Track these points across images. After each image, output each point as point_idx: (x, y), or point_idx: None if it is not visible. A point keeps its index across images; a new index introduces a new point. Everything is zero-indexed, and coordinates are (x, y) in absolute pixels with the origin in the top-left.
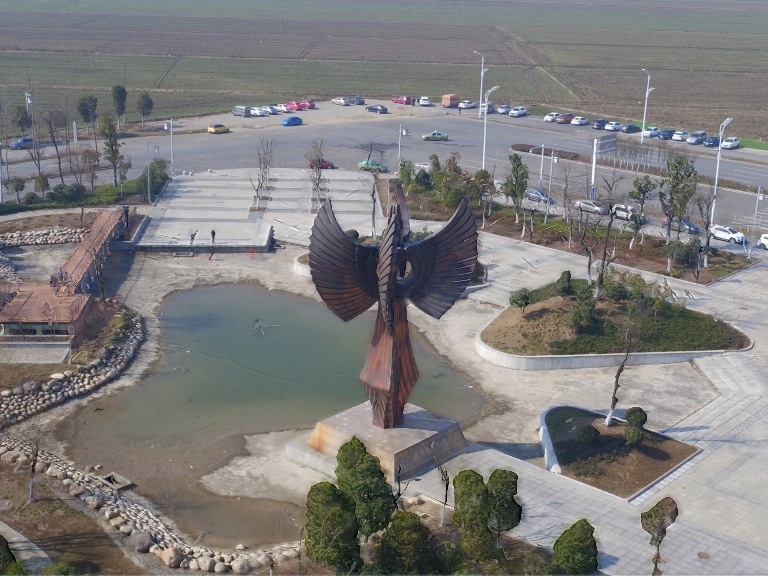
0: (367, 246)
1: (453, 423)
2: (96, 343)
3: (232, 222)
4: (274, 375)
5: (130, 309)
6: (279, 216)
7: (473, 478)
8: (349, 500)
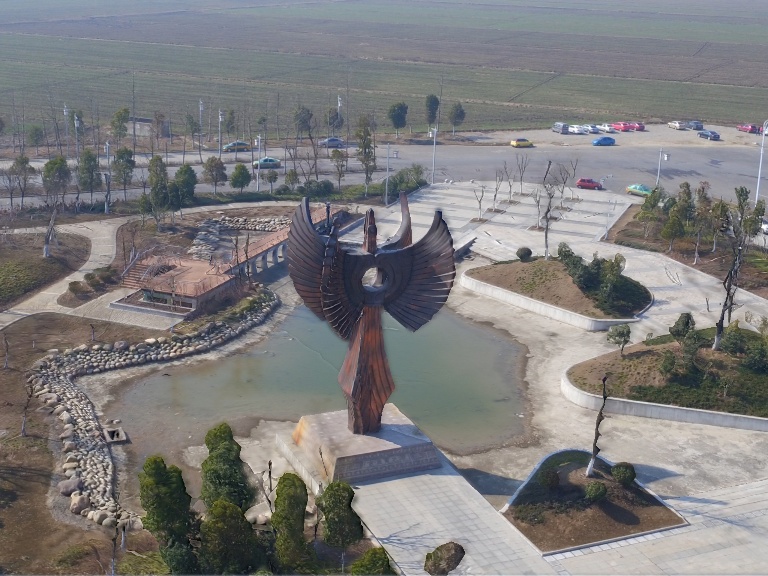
0: None
1: (426, 441)
2: (211, 319)
3: None
4: None
5: (271, 294)
6: (493, 229)
7: (289, 482)
8: (171, 478)
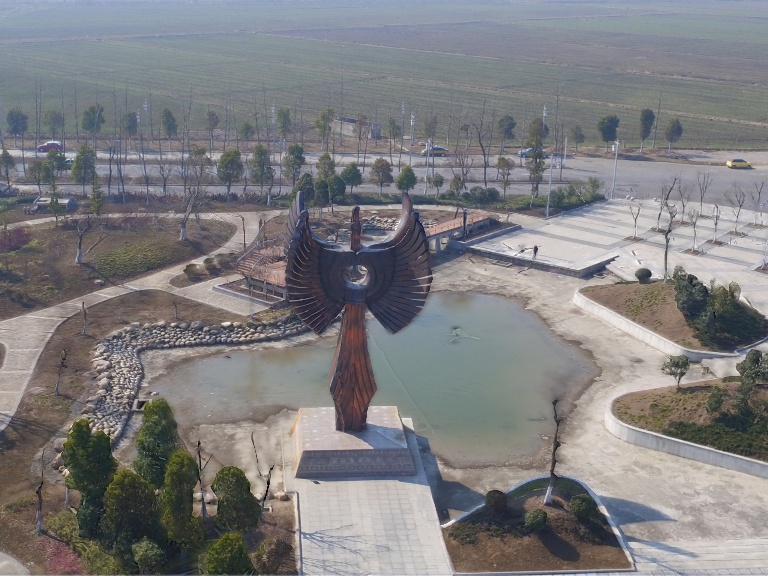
0: (324, 243)
1: (402, 447)
2: None
3: (587, 245)
4: (402, 375)
5: None
6: (643, 249)
7: (178, 459)
8: (89, 442)
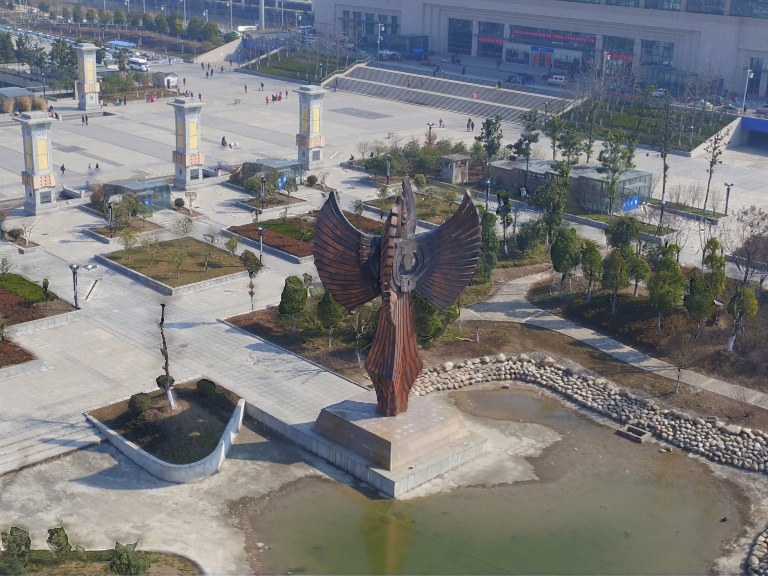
0: (427, 232)
1: (329, 408)
2: None
3: None
4: None
5: None
6: None
7: None
8: None
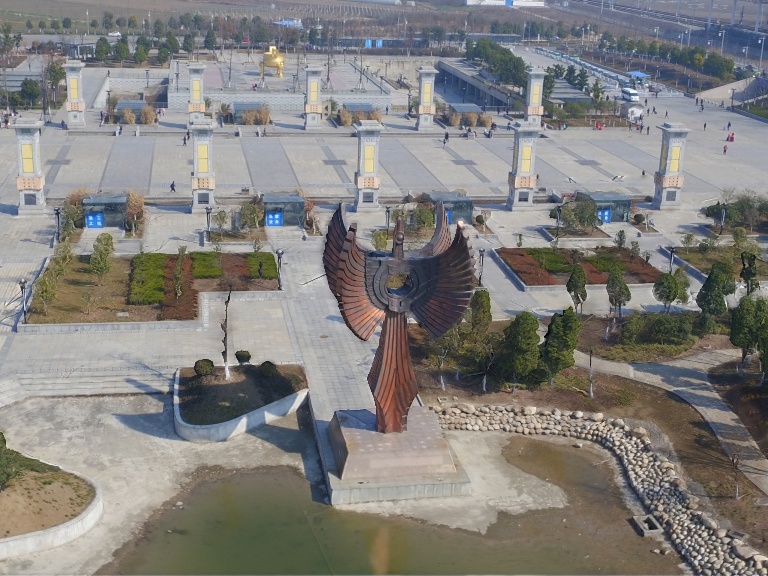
0: None
1: (342, 411)
2: None
3: None
4: None
5: None
6: None
7: None
8: None
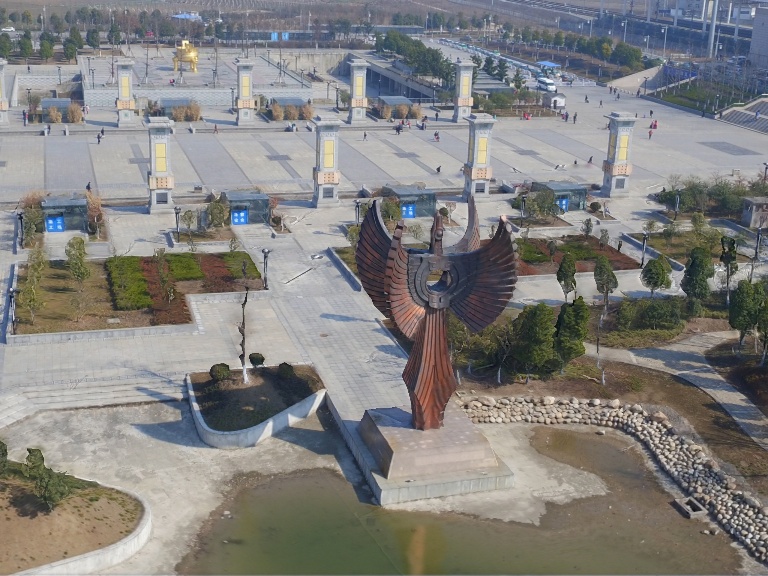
0: None
1: (373, 410)
2: None
3: None
4: None
5: None
6: None
7: None
8: None
